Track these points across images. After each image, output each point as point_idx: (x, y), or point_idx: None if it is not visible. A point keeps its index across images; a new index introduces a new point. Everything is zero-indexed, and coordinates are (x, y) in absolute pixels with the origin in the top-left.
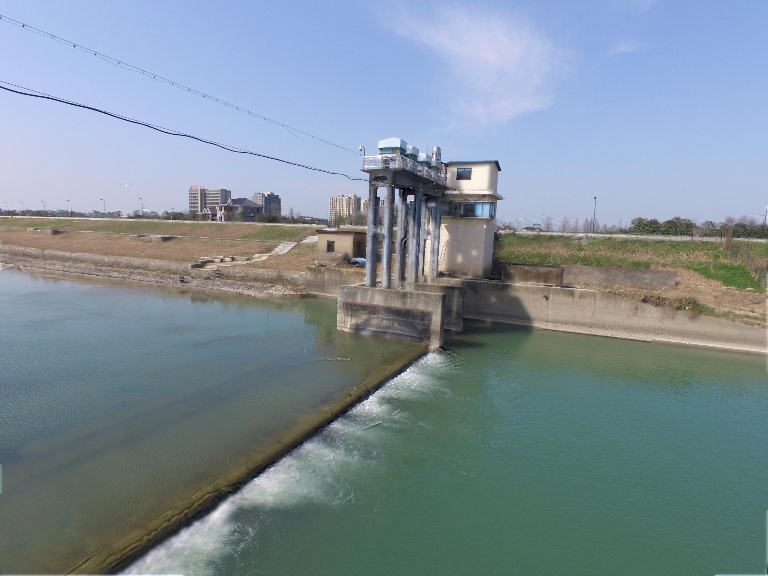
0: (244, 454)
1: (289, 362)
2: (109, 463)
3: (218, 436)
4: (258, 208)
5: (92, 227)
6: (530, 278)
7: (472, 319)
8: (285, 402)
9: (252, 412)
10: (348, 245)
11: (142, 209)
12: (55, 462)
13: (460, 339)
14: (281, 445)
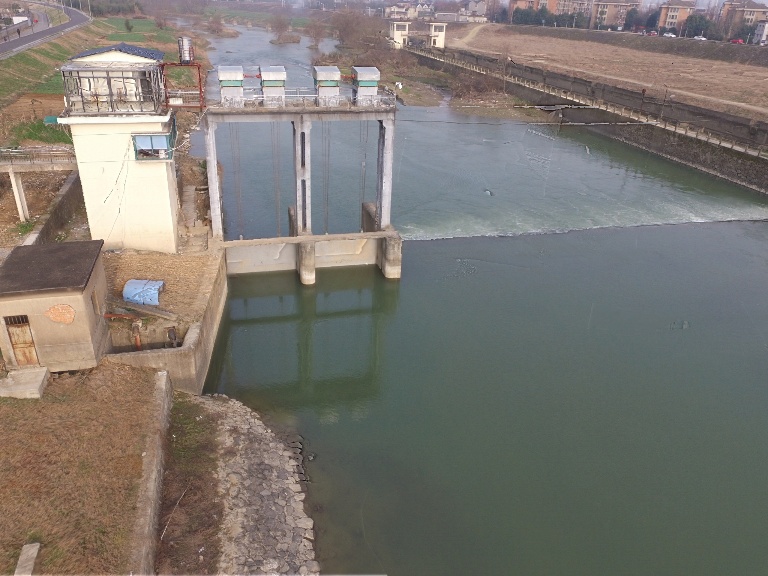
0: (572, 235)
1: (497, 266)
2: (616, 248)
3: (575, 244)
4: None
5: None
6: None
7: None
8: (534, 246)
9: (553, 248)
10: (103, 277)
11: None
12: (635, 255)
13: None
14: (557, 233)
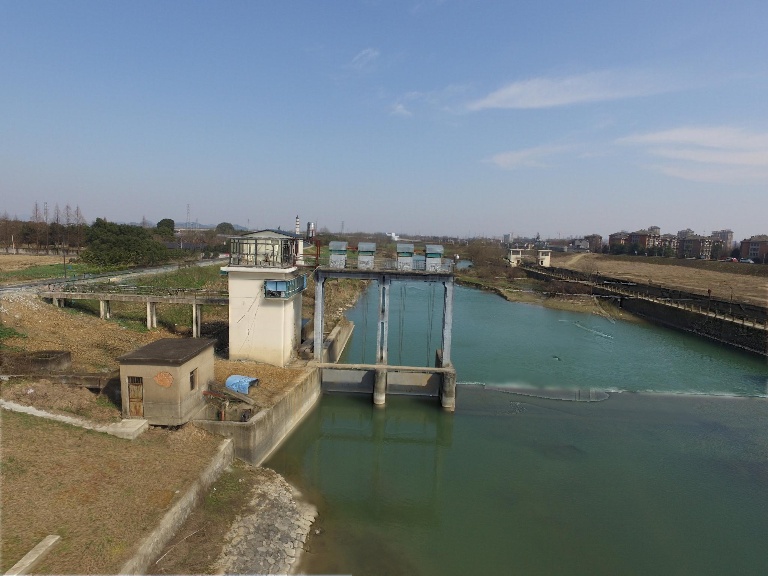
0: None
1: (546, 410)
2: (668, 409)
3: (627, 402)
4: None
5: None
6: None
7: None
8: None
9: None
10: (210, 365)
11: None
12: None
13: None
14: None
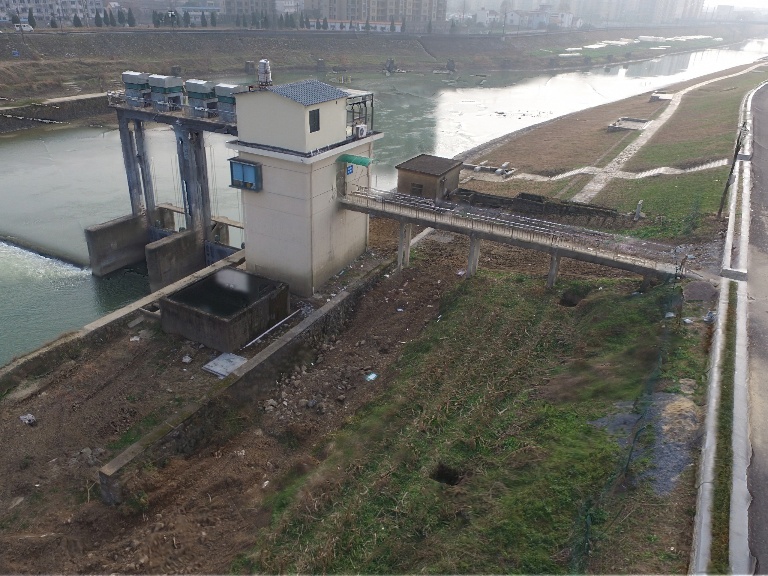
0: None
1: None
2: None
3: None
4: None
5: (711, 96)
6: None
7: None
8: None
9: (15, 222)
10: None
11: None
12: None
13: None
14: None
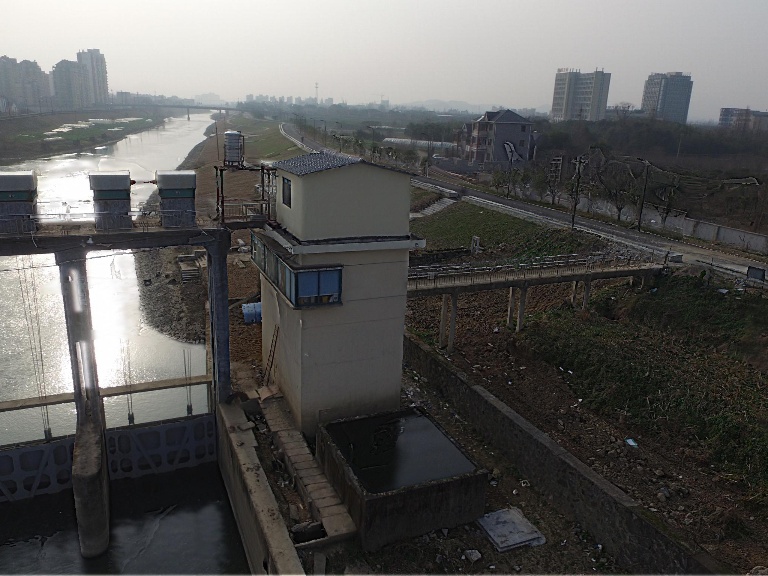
0: None
1: None
2: None
3: None
4: (524, 125)
5: None
6: (337, 481)
7: (234, 516)
8: None
9: None
10: None
11: (341, 136)
12: None
13: (76, 573)
14: None
